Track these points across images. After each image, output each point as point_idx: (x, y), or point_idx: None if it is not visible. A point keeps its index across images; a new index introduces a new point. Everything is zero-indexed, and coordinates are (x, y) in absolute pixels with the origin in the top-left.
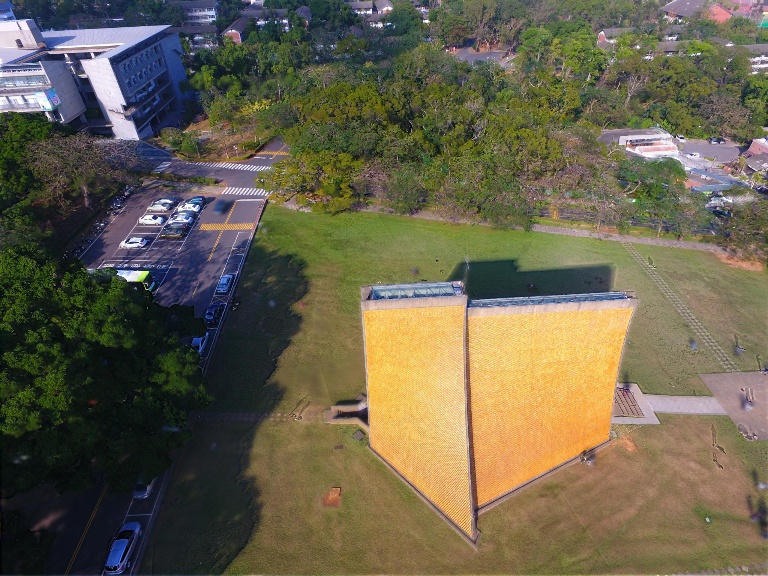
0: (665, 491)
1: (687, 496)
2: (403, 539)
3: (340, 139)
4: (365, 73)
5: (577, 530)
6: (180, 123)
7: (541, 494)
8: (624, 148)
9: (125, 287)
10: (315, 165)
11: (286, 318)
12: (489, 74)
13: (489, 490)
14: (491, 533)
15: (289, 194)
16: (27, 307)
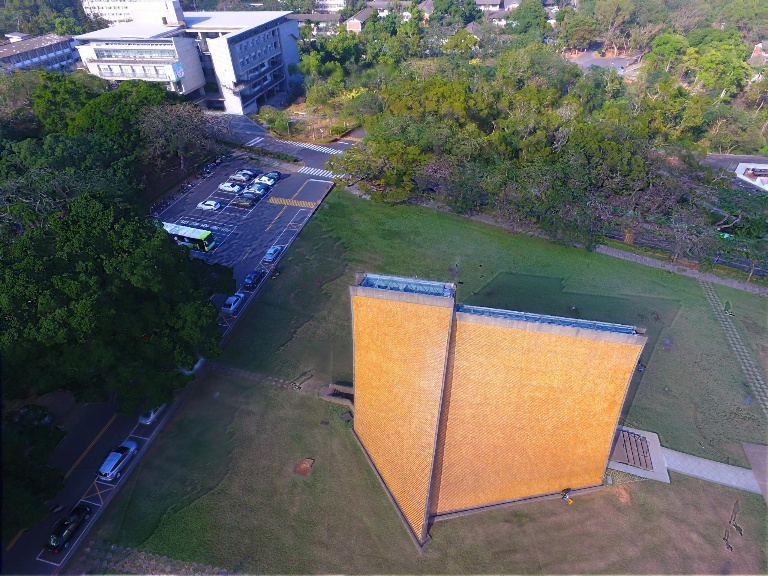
0: (649, 555)
1: (674, 567)
2: (355, 522)
3: (413, 132)
4: (466, 69)
5: (532, 565)
6: (283, 103)
7: (506, 519)
8: (733, 176)
9: (165, 239)
10: (382, 155)
11: (317, 295)
12: (603, 81)
13: (452, 500)
14: (441, 542)
15: (353, 179)
16: (83, 242)
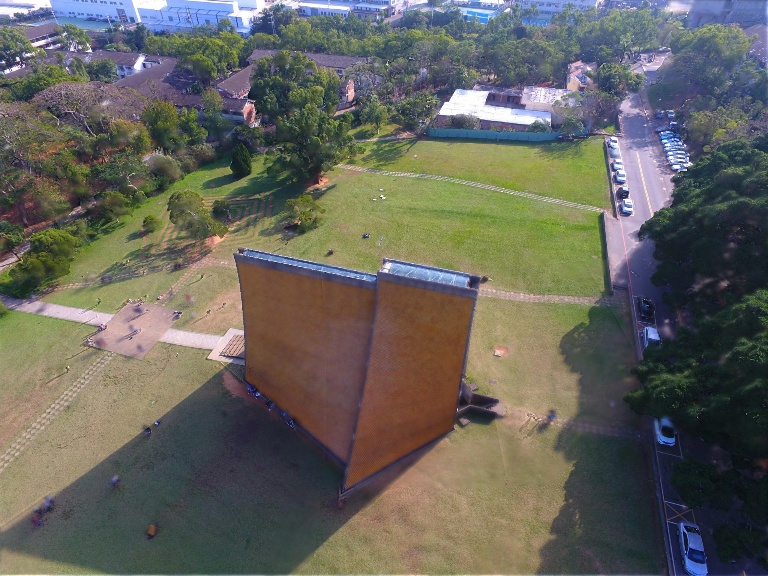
0: None
1: None
2: None
3: None
4: None
5: None
6: None
7: None
8: None
9: None
10: None
11: None
12: None
13: None
14: None
15: None
16: None
